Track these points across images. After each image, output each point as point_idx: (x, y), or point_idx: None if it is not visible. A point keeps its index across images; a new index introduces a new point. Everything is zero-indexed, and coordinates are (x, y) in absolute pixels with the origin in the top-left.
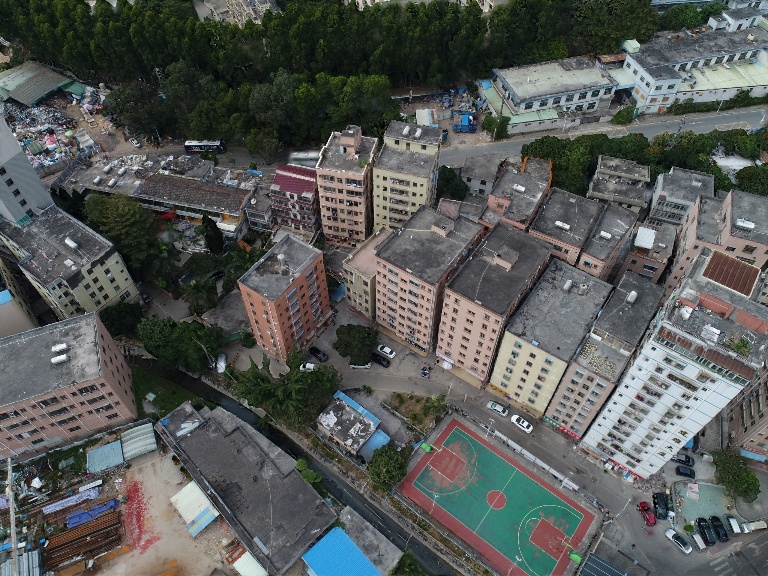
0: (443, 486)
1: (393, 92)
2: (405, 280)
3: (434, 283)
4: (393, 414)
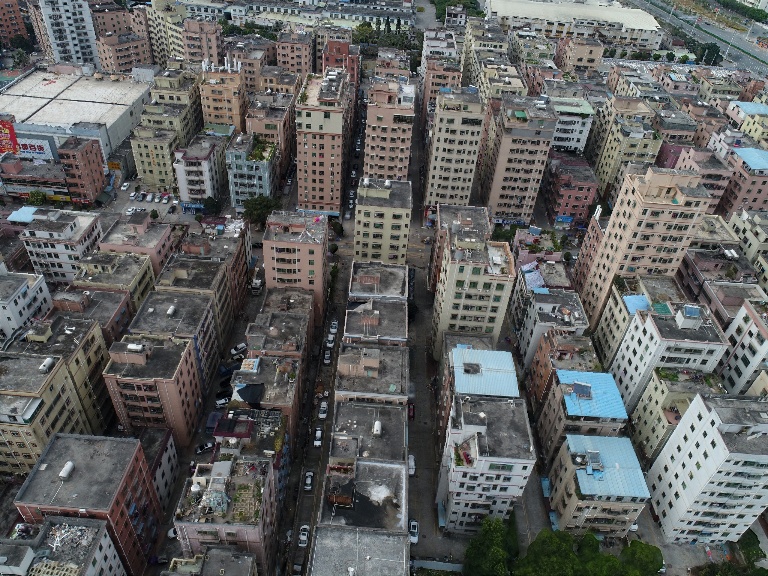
0: (3, 75)
1: (142, 1)
2: (29, 7)
3: (31, 4)
4: (13, 63)
